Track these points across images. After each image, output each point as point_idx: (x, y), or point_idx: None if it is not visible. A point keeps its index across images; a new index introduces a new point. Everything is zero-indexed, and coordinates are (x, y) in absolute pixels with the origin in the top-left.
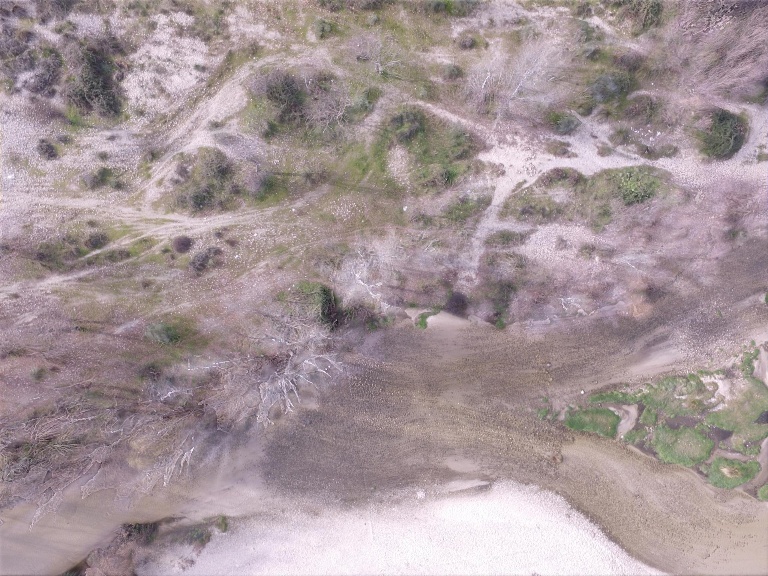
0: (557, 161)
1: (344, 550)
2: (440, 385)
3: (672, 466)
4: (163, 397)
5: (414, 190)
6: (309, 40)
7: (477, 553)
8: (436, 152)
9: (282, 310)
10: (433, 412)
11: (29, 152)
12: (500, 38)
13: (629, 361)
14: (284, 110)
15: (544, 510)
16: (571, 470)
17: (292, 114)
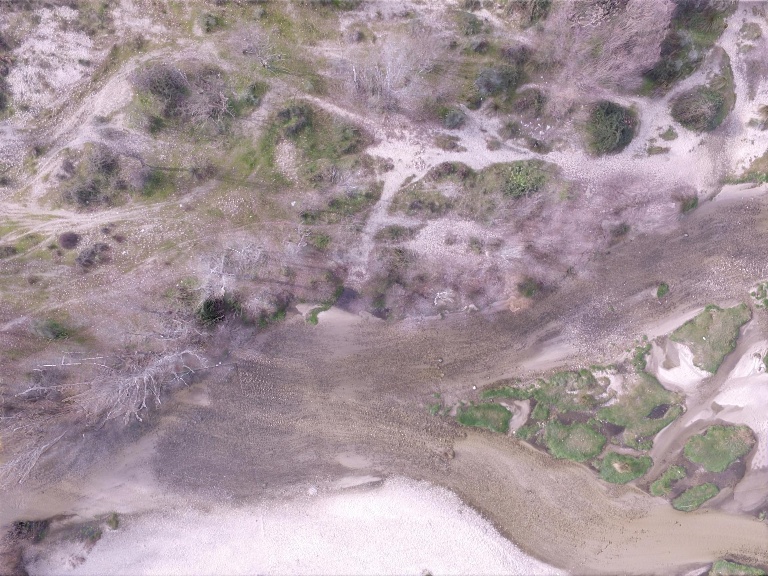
0: (446, 155)
1: (235, 547)
2: (331, 381)
3: (564, 461)
4: (18, 394)
5: (302, 185)
6: (195, 34)
7: (368, 549)
8: (324, 147)
9: (170, 306)
10: (325, 408)
11: None
12: (388, 31)
13: (521, 356)
14: (168, 105)
15: (436, 506)
16: (463, 466)
17: (177, 109)
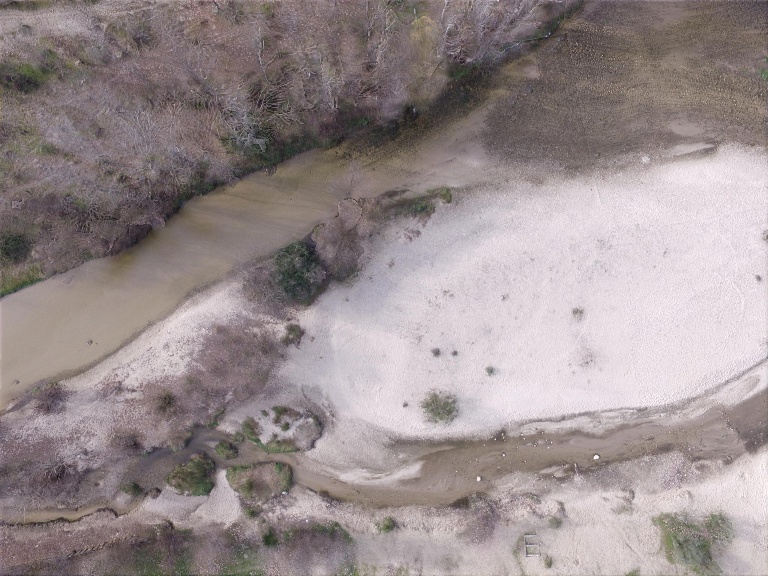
0: None
1: (572, 214)
2: (662, 49)
3: None
4: None
5: None
6: None
7: (707, 212)
8: None
9: None
10: (656, 76)
11: None
12: None
13: None
14: None
15: None
16: None
17: None
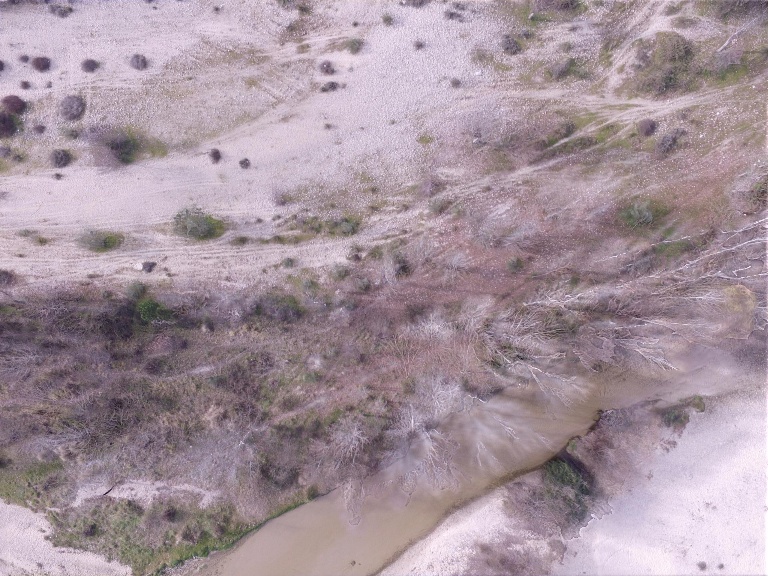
0: None
1: None
2: None
3: None
4: None
5: None
6: None
7: None
8: None
9: (750, 185)
10: None
11: (494, 48)
12: None
13: None
14: None
15: None
16: None
17: None
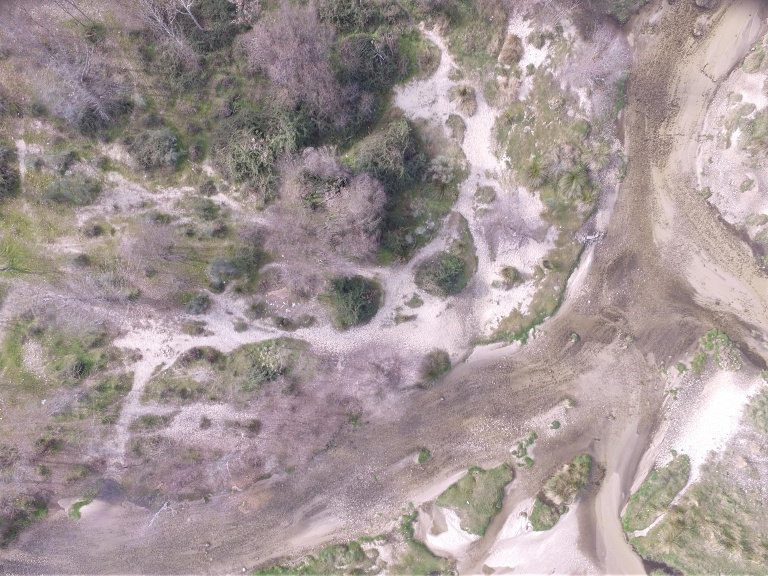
0: (194, 341)
1: None
2: (99, 575)
3: None
4: None
5: (52, 382)
6: None
7: None
8: (70, 343)
9: None
10: None
11: None
12: (126, 223)
13: (289, 534)
14: None
15: None
16: None
17: None
